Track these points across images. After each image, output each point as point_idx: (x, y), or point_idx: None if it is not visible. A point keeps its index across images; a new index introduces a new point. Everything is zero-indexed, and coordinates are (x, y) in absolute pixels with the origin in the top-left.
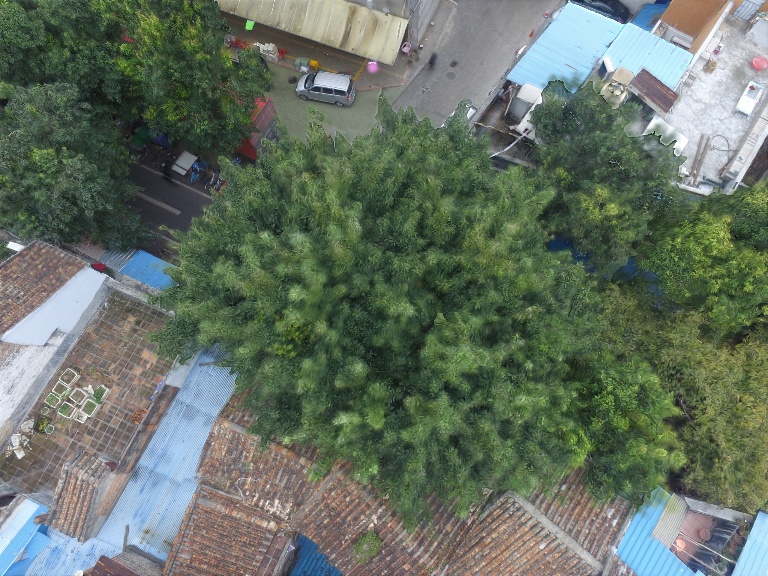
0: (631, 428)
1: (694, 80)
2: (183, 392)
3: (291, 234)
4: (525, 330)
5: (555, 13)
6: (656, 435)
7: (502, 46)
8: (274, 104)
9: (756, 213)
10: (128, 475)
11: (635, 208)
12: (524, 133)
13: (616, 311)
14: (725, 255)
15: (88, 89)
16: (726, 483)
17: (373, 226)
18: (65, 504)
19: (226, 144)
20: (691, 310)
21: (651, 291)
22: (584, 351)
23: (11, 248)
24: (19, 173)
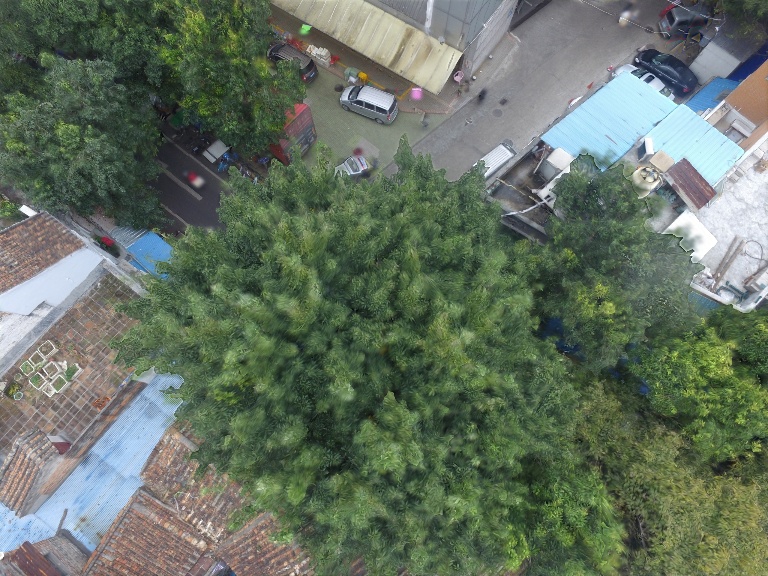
0: (576, 544)
1: (741, 177)
2: (150, 388)
3: (264, 274)
4: (483, 421)
5: (619, 69)
6: (600, 559)
7: (557, 92)
8: (316, 109)
9: (766, 343)
10: (78, 460)
11: (637, 308)
12: (545, 199)
13: (596, 409)
14: (724, 379)
15: (131, 69)
16: None
17: (349, 282)
18: (11, 476)
19: (253, 145)
20: (677, 425)
21: (640, 394)
22: (544, 453)
23: (23, 211)
24: (42, 143)
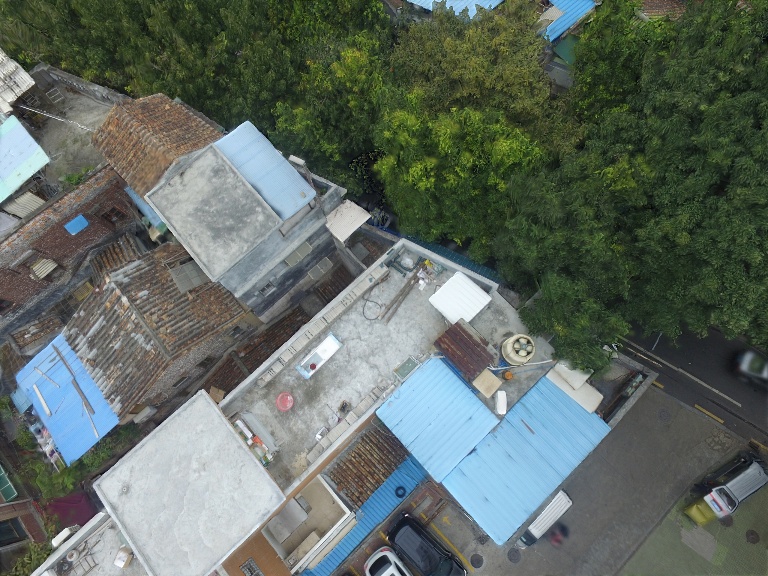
0: None
1: None
2: None
3: None
4: None
5: None
6: None
7: None
8: None
9: None
10: None
11: None
12: None
13: None
14: None
15: None
16: (536, 8)
17: None
18: None
19: None
20: None
21: None
22: None
23: None
24: None
